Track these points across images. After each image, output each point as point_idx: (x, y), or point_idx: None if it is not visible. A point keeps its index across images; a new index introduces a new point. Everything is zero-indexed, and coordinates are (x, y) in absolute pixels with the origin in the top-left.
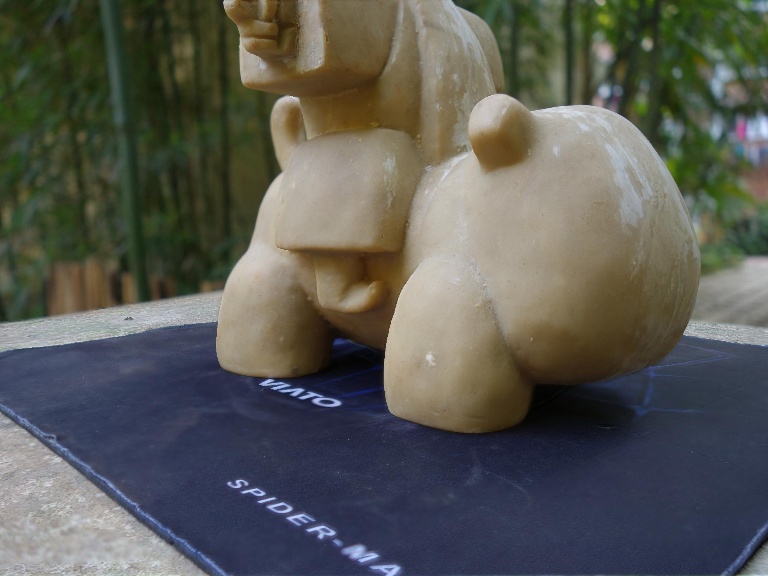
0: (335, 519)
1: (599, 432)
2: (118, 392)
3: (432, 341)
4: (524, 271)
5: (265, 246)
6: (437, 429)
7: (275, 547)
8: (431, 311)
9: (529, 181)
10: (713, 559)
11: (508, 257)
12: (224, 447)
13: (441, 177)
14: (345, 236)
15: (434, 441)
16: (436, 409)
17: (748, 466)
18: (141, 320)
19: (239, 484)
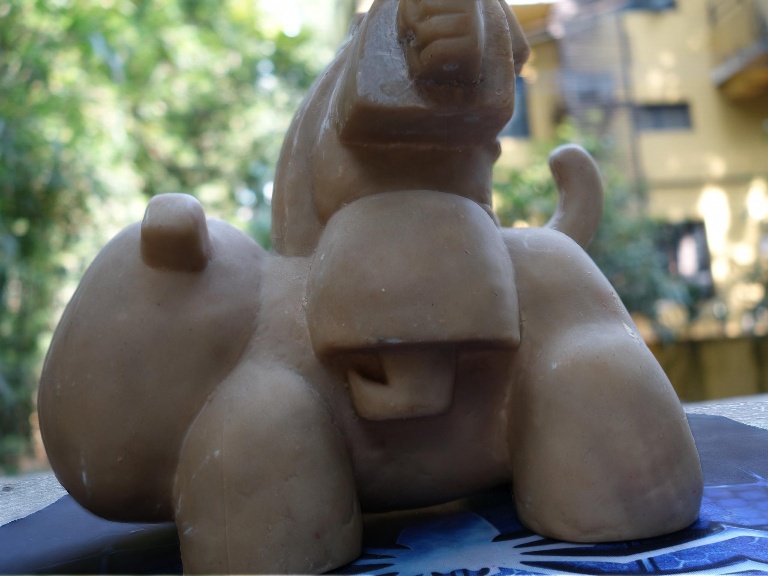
0: None
1: (139, 527)
2: None
3: None
4: None
5: None
6: None
7: None
8: None
9: None
10: None
11: None
12: None
13: None
14: None
15: None
16: None
17: (14, 542)
18: None
19: None
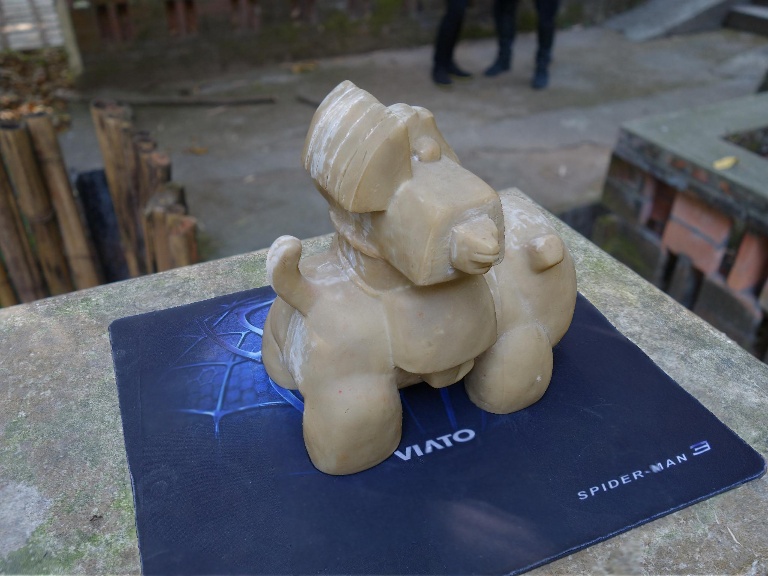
0: (628, 468)
1: None
2: (386, 545)
3: (539, 370)
4: (562, 314)
5: (370, 375)
6: (532, 405)
7: (649, 492)
8: (536, 357)
9: (560, 272)
10: (671, 384)
11: (555, 311)
12: (531, 494)
13: (494, 279)
14: (486, 345)
15: (548, 411)
16: (537, 397)
17: None
18: (12, 527)
19: (584, 495)
